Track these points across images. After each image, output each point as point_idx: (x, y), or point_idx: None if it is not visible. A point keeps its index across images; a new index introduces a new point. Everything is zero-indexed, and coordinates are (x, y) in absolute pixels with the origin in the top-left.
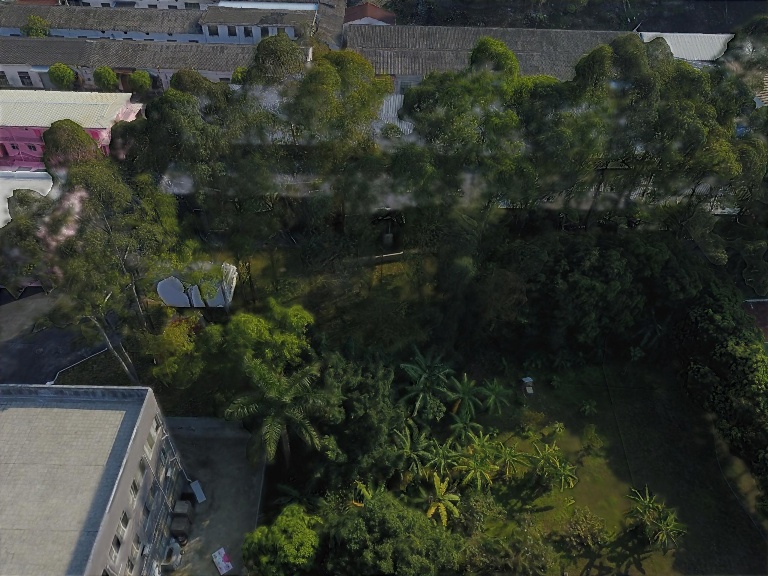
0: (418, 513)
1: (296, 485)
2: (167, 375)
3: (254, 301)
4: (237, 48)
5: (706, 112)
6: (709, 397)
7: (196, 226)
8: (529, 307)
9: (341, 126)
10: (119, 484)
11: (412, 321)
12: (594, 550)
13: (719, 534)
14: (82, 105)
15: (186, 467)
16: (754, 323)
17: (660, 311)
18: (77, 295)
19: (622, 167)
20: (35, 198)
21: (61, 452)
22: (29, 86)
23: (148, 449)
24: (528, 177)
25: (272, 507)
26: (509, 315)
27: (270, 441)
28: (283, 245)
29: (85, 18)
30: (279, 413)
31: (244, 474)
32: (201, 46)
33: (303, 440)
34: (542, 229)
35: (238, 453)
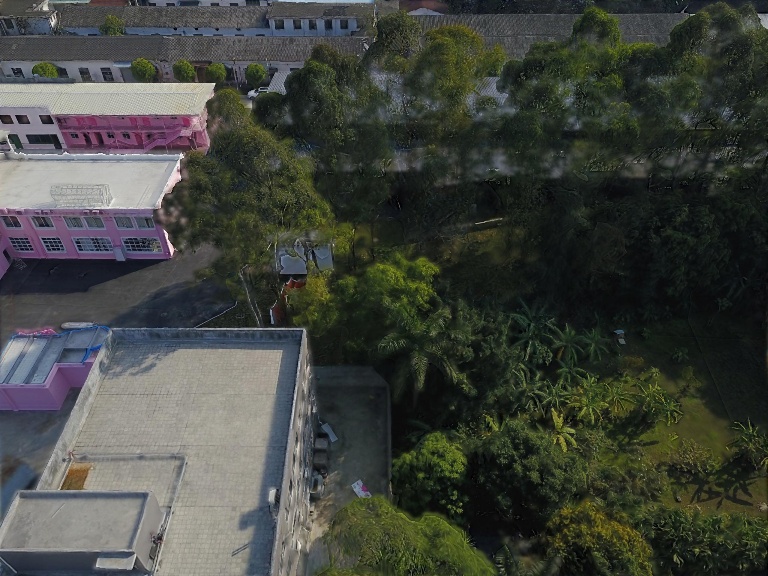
0: None
1: (427, 420)
2: (307, 323)
3: (355, 267)
4: (305, 40)
5: None
6: None
7: (327, 188)
8: (624, 261)
9: (451, 96)
10: (296, 406)
11: (518, 275)
12: (702, 477)
13: None
14: (173, 94)
15: None
16: None
17: (744, 264)
18: (244, 244)
19: (709, 128)
20: (204, 159)
21: (234, 384)
22: (110, 81)
23: (303, 384)
24: (633, 134)
25: (401, 444)
26: (609, 267)
27: (420, 371)
28: (386, 212)
29: (158, 16)
30: (421, 349)
31: (369, 417)
32: (271, 39)
33: None
34: (632, 189)
35: (360, 400)
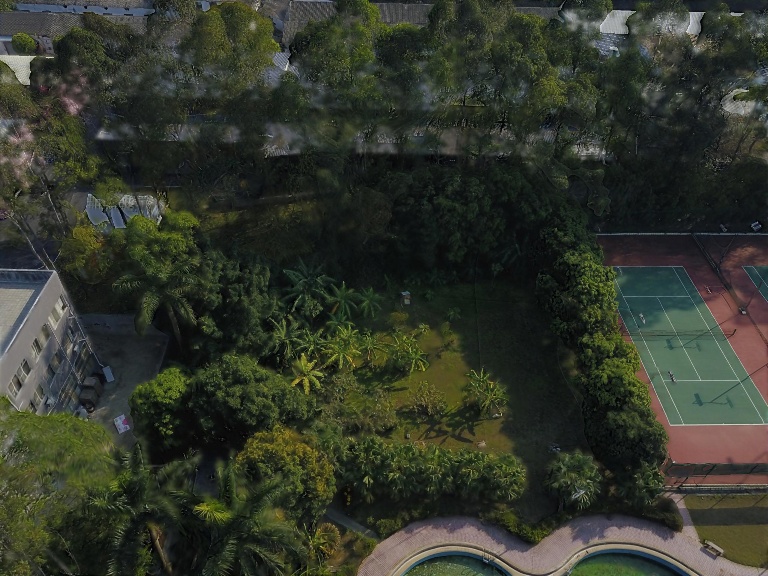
0: (280, 379)
1: (184, 361)
2: (77, 270)
3: None
4: None
5: (535, 52)
6: (549, 300)
7: (104, 147)
8: (400, 226)
9: (233, 67)
10: (19, 334)
11: (295, 234)
12: (436, 419)
13: (545, 408)
14: None
15: (101, 356)
16: (595, 241)
17: (520, 233)
18: None
19: (479, 105)
20: None
21: None
22: None
23: (53, 321)
24: (380, 105)
25: None
26: (378, 229)
27: (148, 309)
28: (195, 177)
29: None
30: (160, 291)
31: (149, 362)
32: None
33: (183, 317)
34: (416, 161)
35: (147, 347)
